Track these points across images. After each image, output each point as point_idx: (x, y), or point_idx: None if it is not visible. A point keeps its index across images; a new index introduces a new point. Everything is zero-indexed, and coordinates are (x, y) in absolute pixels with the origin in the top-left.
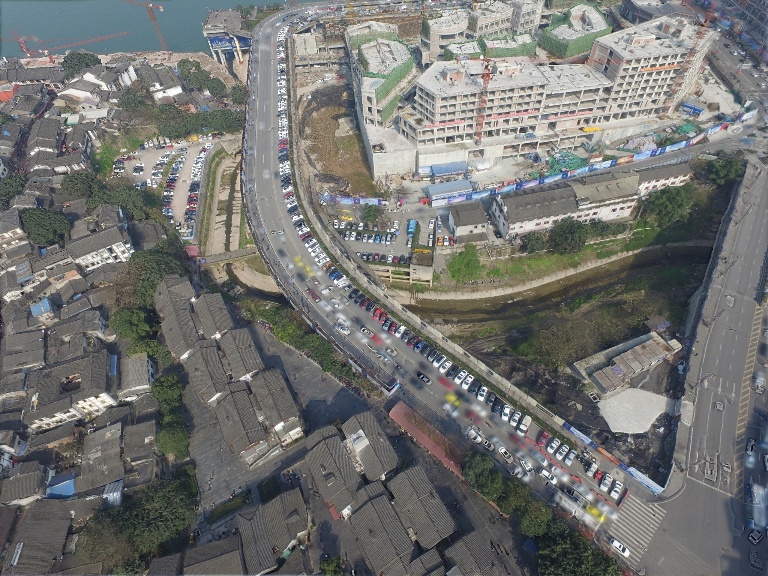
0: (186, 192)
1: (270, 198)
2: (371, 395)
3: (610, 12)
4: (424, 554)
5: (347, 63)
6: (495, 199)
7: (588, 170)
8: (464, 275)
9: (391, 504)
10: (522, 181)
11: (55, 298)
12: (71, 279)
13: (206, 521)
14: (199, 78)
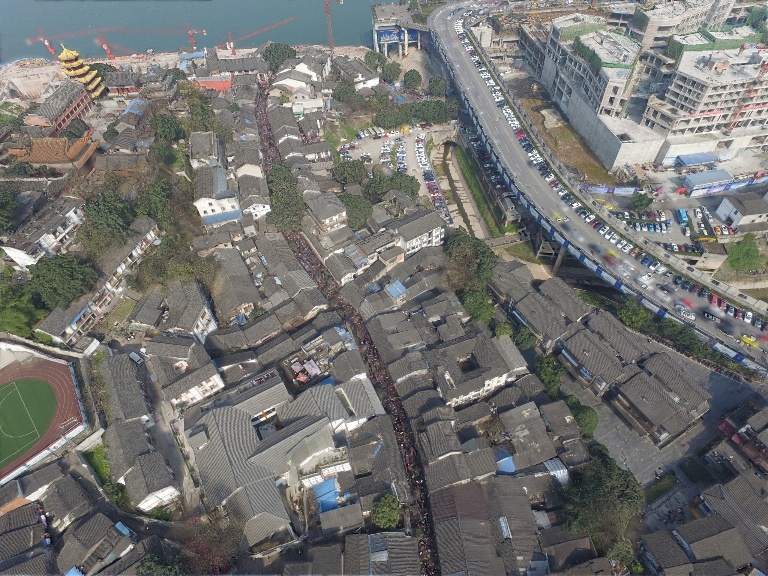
0: (422, 181)
1: (536, 186)
2: (752, 379)
3: None
4: None
5: (523, 56)
6: None
7: None
8: (743, 265)
9: None
10: None
11: None
12: (398, 262)
13: (645, 500)
14: (392, 70)
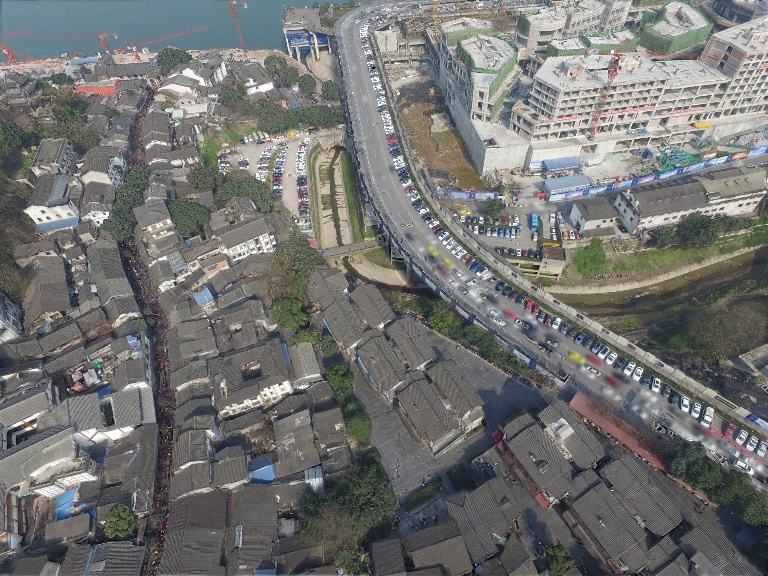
0: (294, 186)
1: (391, 192)
2: (542, 386)
3: (701, 9)
4: (661, 541)
5: (428, 60)
6: (621, 194)
7: (703, 166)
8: (590, 269)
9: (611, 492)
10: (636, 176)
11: (208, 288)
12: (221, 269)
13: (404, 508)
14: (288, 74)
